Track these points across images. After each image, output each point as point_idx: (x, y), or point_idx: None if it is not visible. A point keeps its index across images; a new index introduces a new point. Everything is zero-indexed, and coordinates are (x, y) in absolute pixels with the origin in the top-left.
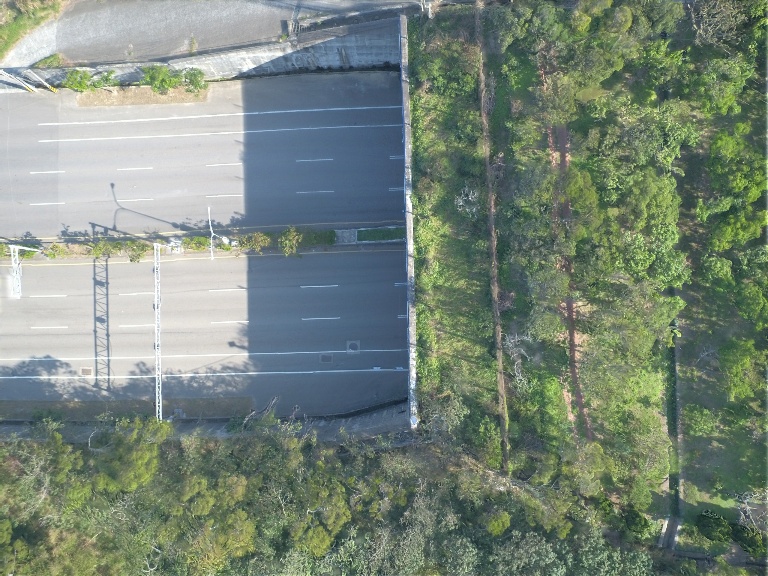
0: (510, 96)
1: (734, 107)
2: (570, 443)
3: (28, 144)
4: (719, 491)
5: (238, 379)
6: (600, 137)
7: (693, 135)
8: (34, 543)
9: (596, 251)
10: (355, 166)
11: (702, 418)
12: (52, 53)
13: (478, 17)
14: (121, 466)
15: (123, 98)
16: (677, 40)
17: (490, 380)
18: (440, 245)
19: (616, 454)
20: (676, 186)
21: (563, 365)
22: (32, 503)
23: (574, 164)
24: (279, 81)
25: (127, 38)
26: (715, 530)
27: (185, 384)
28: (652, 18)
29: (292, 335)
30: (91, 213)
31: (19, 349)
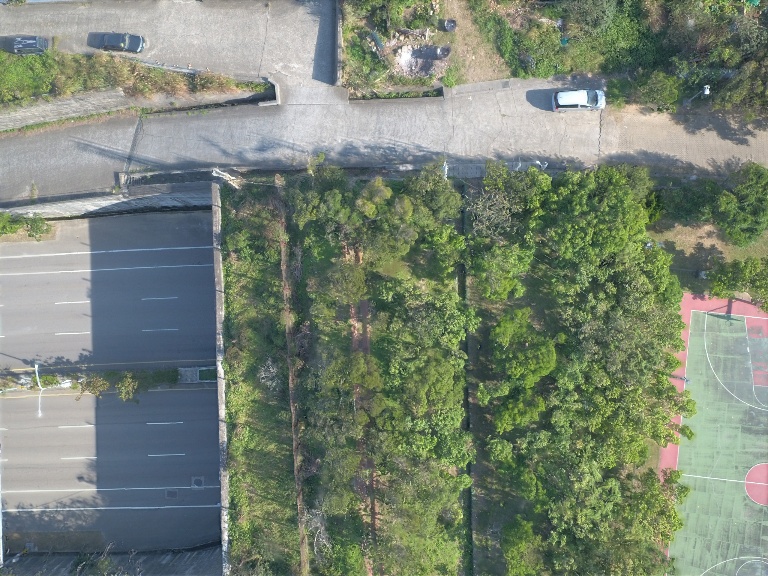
0: (314, 267)
1: (515, 292)
2: None
3: None
4: None
5: (87, 513)
6: (389, 318)
7: (472, 322)
8: None
9: (379, 436)
10: (199, 304)
11: None
12: None
13: (282, 189)
14: None
15: None
16: None
17: None
18: (251, 410)
19: None
20: None
21: (364, 533)
22: None
23: (375, 335)
24: (125, 220)
25: None
26: None
27: (37, 518)
28: (432, 207)
29: (139, 471)
30: None
31: None
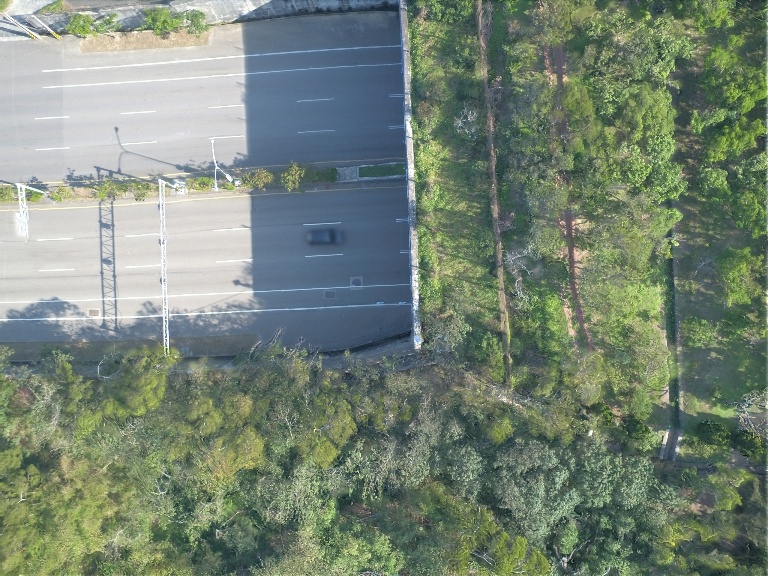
0: (507, 20)
1: (727, 20)
2: (571, 358)
3: (33, 90)
4: (718, 401)
5: (243, 317)
6: (596, 54)
7: (687, 48)
8: (46, 471)
9: (594, 163)
10: (355, 105)
11: (700, 328)
12: None
13: None
14: (130, 392)
15: (125, 43)
16: None
17: (492, 300)
18: (440, 169)
19: (616, 365)
20: (671, 102)
21: (563, 282)
22: (43, 435)
23: None
24: (279, 23)
25: None
26: (714, 434)
27: (191, 323)
28: None
29: (296, 272)
30: (96, 157)
31: (27, 292)
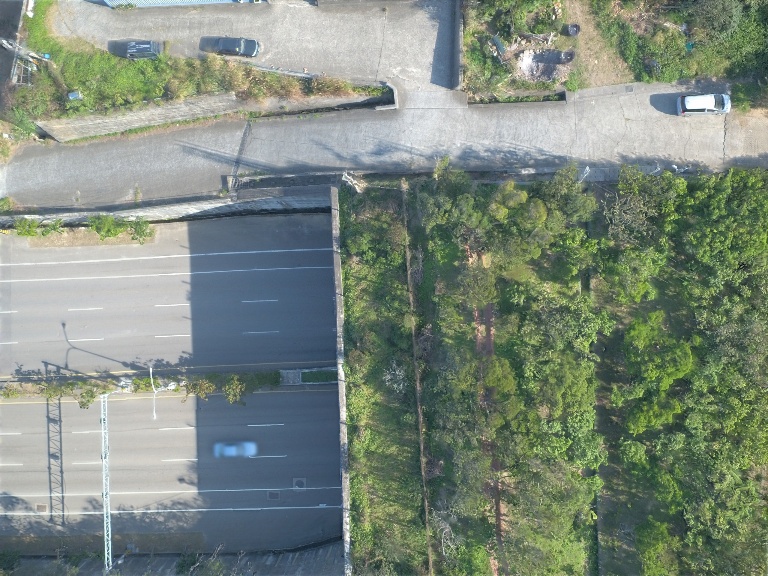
0: (437, 270)
1: (647, 295)
2: None
3: None
4: None
5: (188, 515)
6: (519, 322)
7: (607, 325)
8: None
9: (514, 438)
10: (299, 307)
11: None
12: (3, 196)
13: None
14: None
15: (73, 239)
16: (597, 217)
17: (421, 543)
18: (372, 412)
19: None
20: None
21: None
22: None
23: (499, 338)
24: (224, 223)
25: (74, 184)
26: None
27: (137, 520)
28: (566, 211)
29: (240, 472)
30: (43, 353)
31: None
